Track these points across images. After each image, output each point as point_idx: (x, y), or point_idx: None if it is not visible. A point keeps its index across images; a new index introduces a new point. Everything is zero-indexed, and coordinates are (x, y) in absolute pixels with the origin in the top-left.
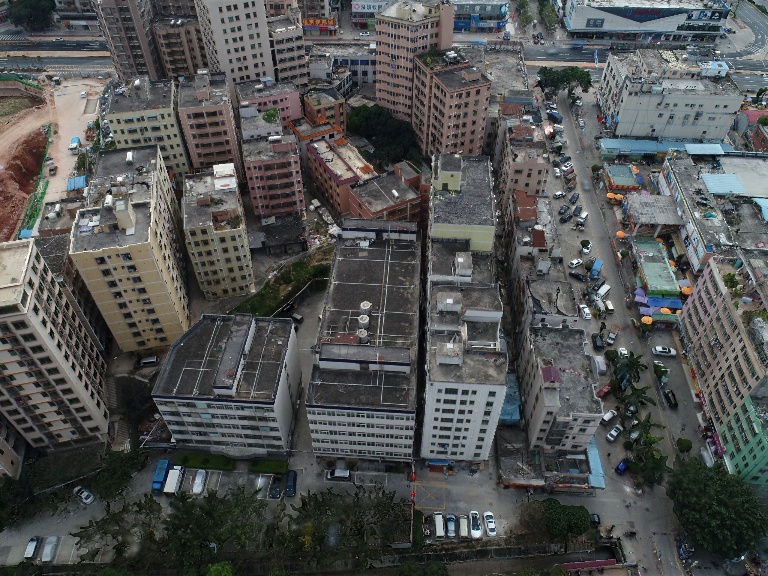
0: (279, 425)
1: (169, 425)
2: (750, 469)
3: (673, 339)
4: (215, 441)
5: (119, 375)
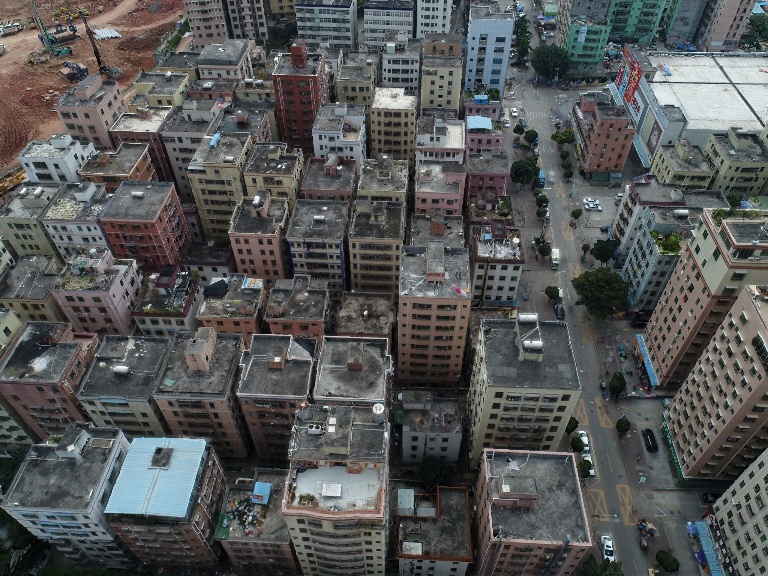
0: (350, 26)
1: (299, 30)
2: (568, 46)
3: (554, 32)
4: (318, 44)
5: (269, 25)
